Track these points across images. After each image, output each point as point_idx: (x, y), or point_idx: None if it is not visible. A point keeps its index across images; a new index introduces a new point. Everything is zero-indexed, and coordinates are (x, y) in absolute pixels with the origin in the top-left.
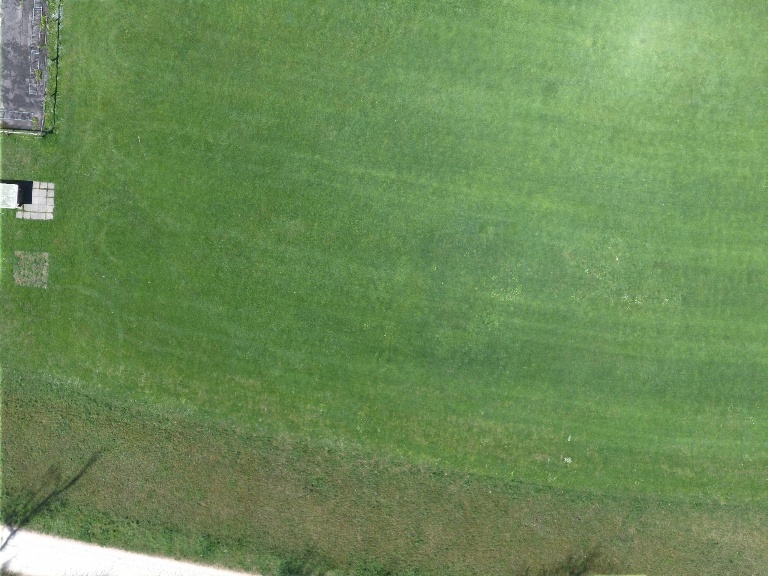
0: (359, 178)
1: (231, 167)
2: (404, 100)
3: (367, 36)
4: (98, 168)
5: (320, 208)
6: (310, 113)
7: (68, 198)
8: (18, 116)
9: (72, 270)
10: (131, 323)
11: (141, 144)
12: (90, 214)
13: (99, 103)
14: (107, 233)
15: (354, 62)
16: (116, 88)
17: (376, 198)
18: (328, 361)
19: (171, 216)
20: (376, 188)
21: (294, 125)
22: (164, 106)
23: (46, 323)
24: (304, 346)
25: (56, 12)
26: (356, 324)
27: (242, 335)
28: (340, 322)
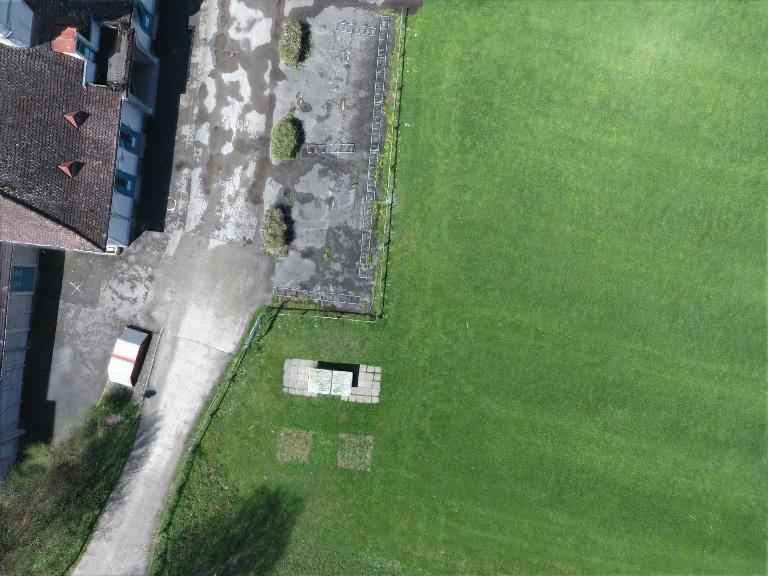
0: (690, 370)
1: (560, 356)
2: (740, 295)
3: (704, 230)
4: (425, 352)
5: (648, 398)
6: (643, 304)
7: (394, 382)
8: (348, 300)
9: (396, 454)
10: (453, 508)
11: (469, 330)
12: (416, 398)
13: (429, 288)
14: (432, 418)
15: (690, 255)
16: (447, 274)
17: (706, 391)
18: (651, 551)
19: (497, 402)
20: (707, 381)
21: (626, 316)
22: (494, 293)
23: (368, 506)
24: (627, 536)
25: (389, 197)
26: (681, 516)
27: (564, 522)
28: (666, 513)
